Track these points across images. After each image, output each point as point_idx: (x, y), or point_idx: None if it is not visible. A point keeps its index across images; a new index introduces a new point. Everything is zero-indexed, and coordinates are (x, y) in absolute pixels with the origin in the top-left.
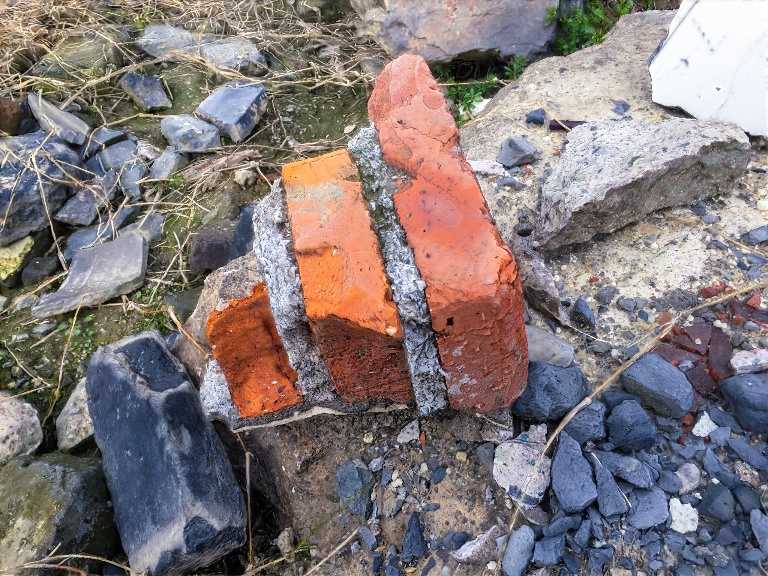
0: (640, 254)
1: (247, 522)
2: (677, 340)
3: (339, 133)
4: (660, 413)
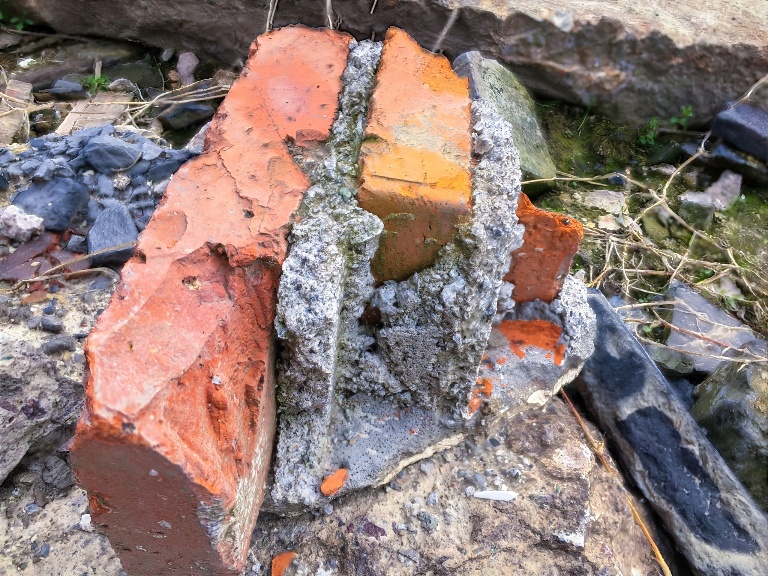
0: None
1: None
2: None
3: None
4: None
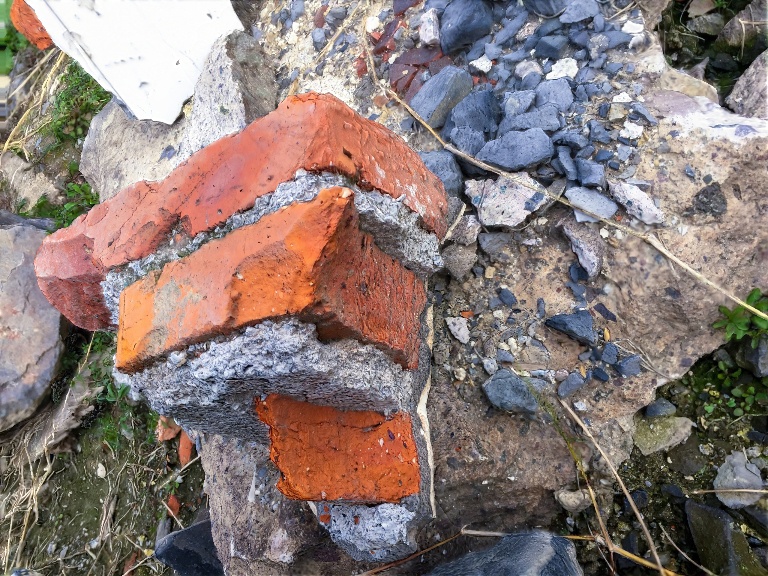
0: None
1: None
2: (401, 88)
3: (102, 486)
4: None
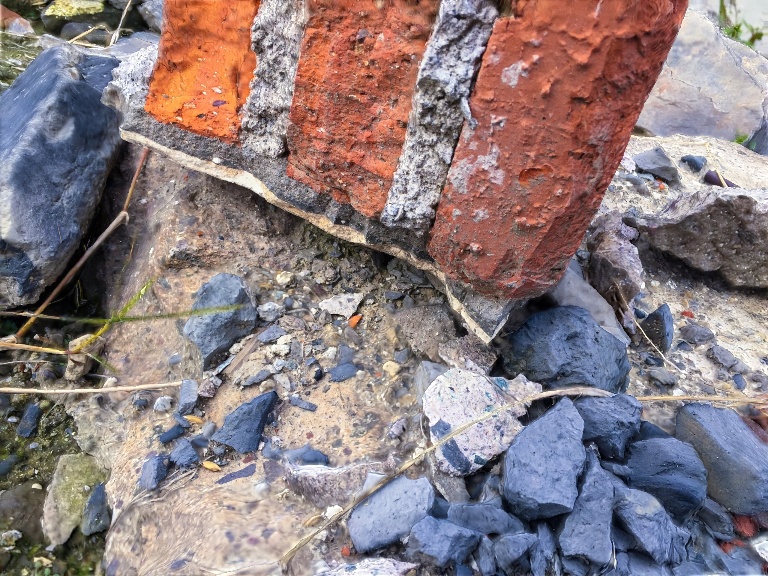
0: (763, 327)
1: (54, 283)
2: None
3: None
4: (713, 496)
